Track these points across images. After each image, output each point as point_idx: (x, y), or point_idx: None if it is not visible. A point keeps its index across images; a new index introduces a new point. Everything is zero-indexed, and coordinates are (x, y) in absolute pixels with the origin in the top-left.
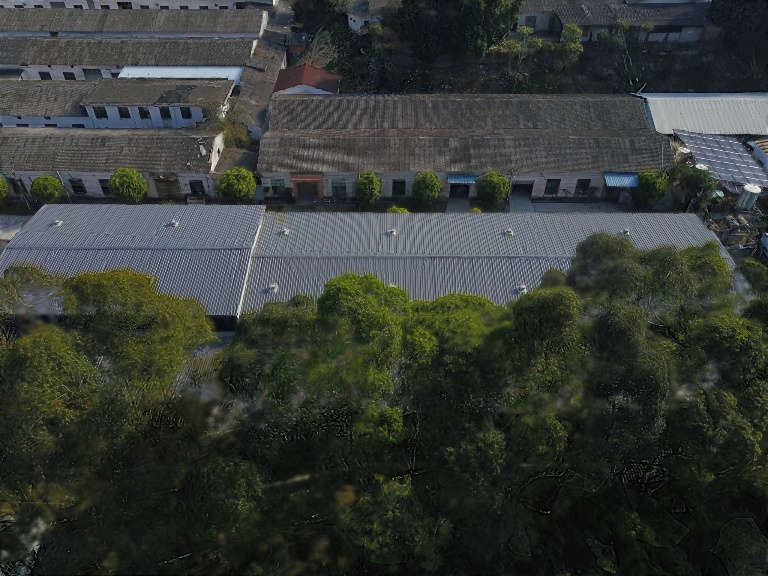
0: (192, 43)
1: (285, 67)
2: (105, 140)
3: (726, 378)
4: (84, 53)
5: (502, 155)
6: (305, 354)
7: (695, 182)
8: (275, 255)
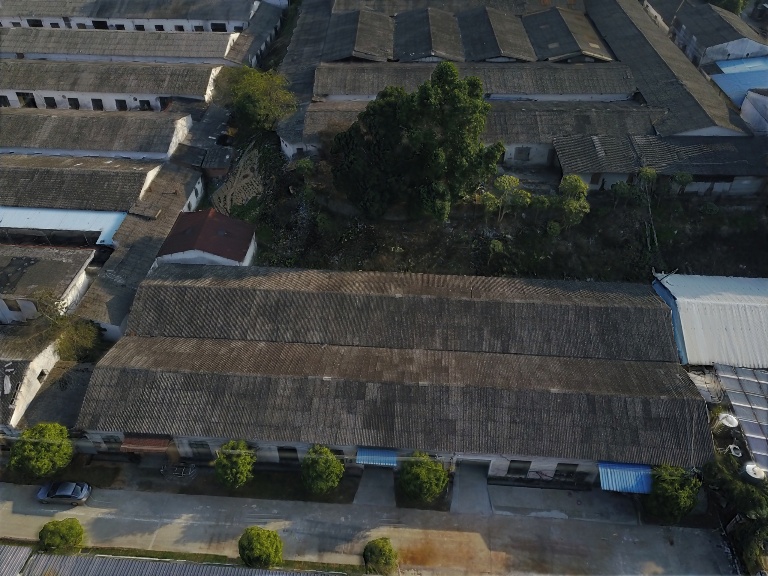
0: (68, 174)
1: (199, 197)
2: None
3: None
4: None
5: (443, 419)
6: None
7: (744, 504)
8: None
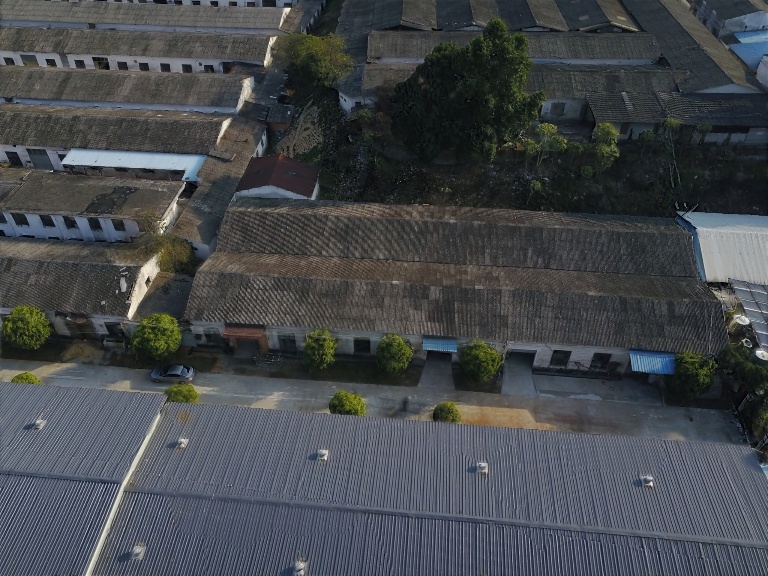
0: (152, 122)
1: (264, 148)
2: (11, 263)
3: None
4: (29, 130)
5: (496, 315)
6: None
7: (754, 380)
8: (156, 490)
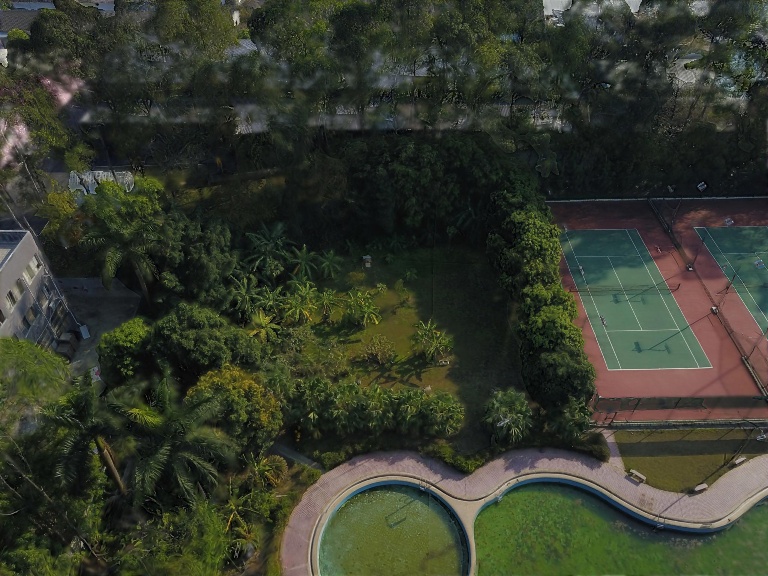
0: None
1: None
2: None
3: (460, 9)
4: None
5: None
6: (284, 8)
7: None
8: None
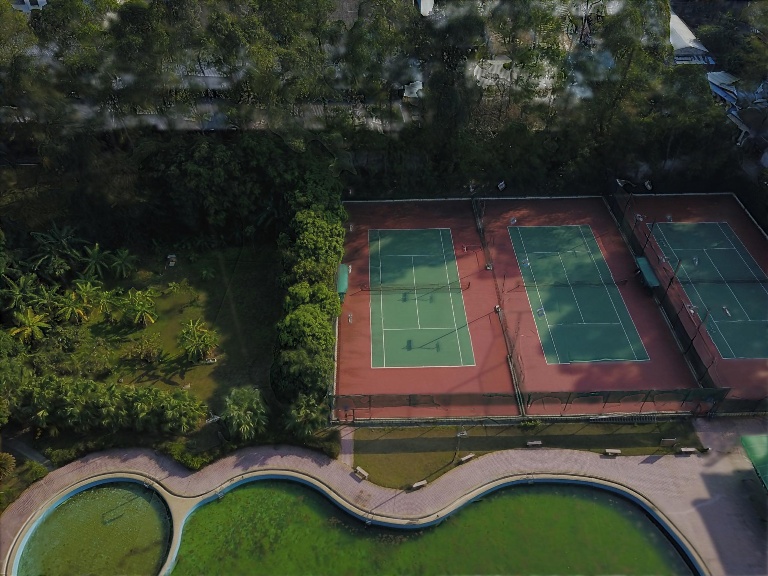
0: None
1: None
2: None
3: (230, 9)
4: None
5: None
6: (60, 8)
7: None
8: None
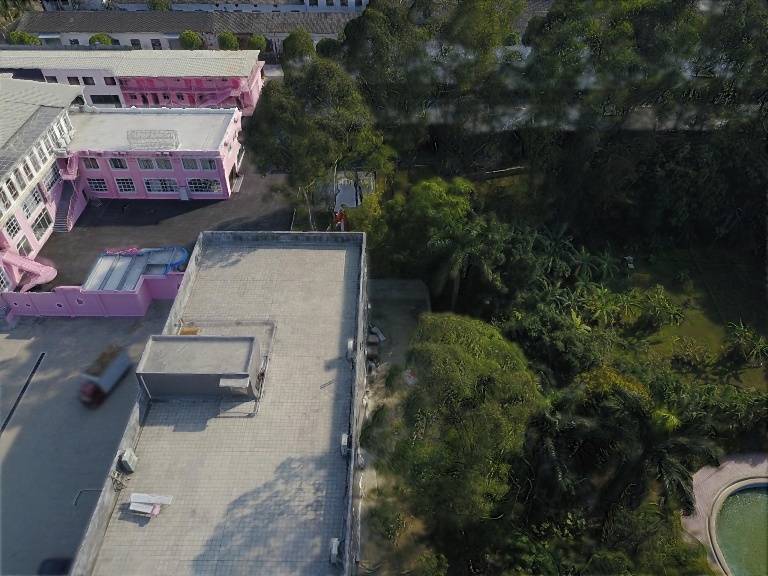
0: None
1: None
2: (327, 15)
3: None
4: None
5: None
6: (585, 8)
7: None
8: None
